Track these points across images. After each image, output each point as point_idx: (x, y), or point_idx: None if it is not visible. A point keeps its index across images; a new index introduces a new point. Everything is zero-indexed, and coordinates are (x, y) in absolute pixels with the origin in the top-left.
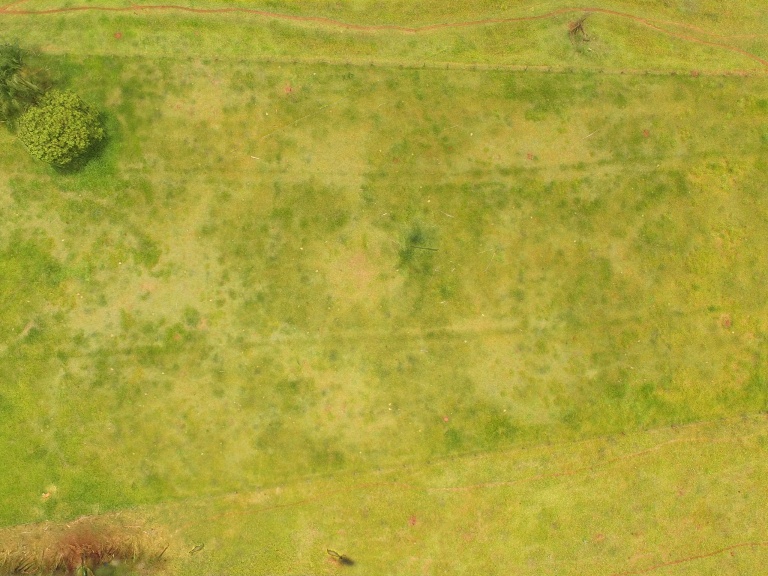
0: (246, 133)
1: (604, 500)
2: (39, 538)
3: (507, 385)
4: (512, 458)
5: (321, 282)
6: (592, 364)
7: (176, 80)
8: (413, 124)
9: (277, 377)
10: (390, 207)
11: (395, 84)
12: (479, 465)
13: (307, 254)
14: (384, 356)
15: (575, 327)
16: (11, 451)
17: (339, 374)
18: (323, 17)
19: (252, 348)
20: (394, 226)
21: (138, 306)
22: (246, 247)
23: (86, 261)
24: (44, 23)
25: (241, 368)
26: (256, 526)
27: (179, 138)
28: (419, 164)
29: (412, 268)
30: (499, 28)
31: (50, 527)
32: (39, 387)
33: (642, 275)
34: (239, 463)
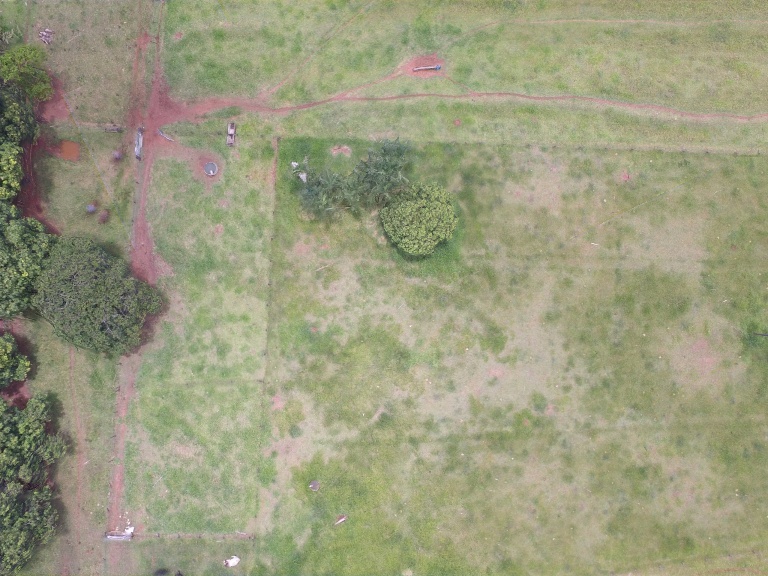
0: (585, 219)
1: None
2: None
3: None
4: None
5: (665, 368)
6: None
7: (515, 167)
8: (749, 211)
9: (625, 463)
10: (730, 294)
11: (730, 171)
12: None
13: (650, 340)
14: (730, 442)
15: None
16: (368, 536)
17: (686, 460)
18: (657, 104)
19: (599, 434)
20: (735, 313)
21: (486, 392)
22: (590, 333)
23: (434, 347)
24: (383, 110)
25: (590, 454)
26: None
27: (520, 224)
28: (757, 251)
29: (754, 355)
30: None
31: None
32: (392, 472)
33: None
34: (590, 548)
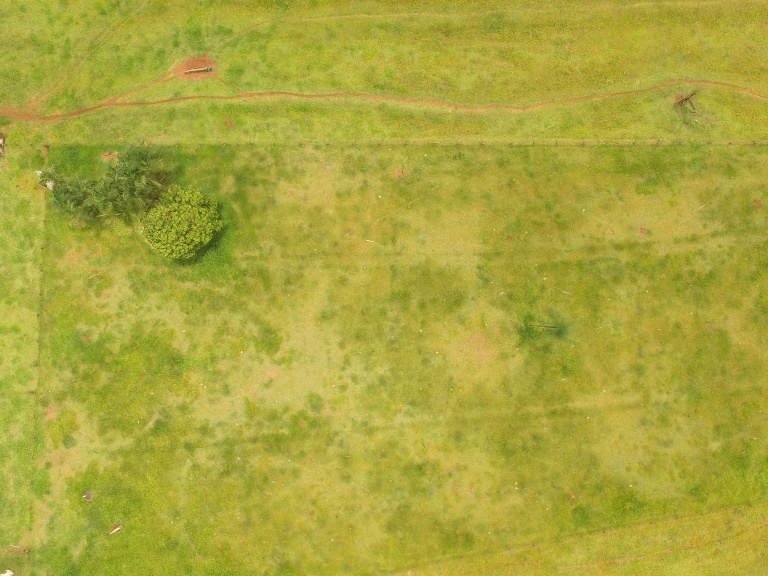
0: (360, 217)
1: (734, 572)
2: None
3: (632, 460)
4: (640, 533)
5: (442, 363)
6: (715, 436)
7: (288, 166)
8: (525, 202)
9: (403, 460)
10: (507, 286)
11: (506, 162)
12: (608, 541)
13: (427, 336)
14: (508, 435)
15: (696, 400)
16: (143, 544)
17: (464, 455)
18: (431, 98)
19: (377, 432)
20: (512, 305)
21: (261, 394)
22: (366, 331)
23: (208, 351)
24: (154, 114)
25: (367, 453)
26: None
27: (294, 224)
28: (533, 242)
29: (532, 346)
30: (606, 103)
31: None
32: (167, 479)
33: (760, 345)
34: (369, 548)
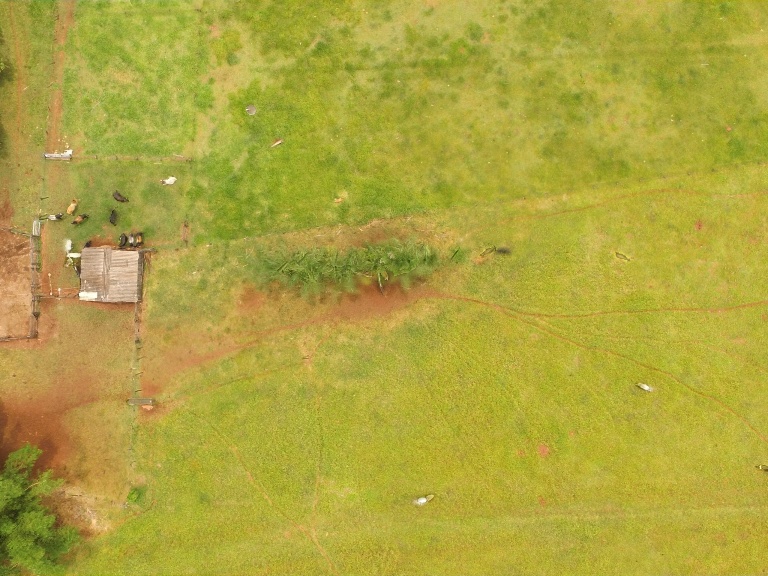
0: None
1: None
2: (332, 241)
3: None
4: None
5: None
6: None
7: None
8: None
9: (560, 89)
10: None
11: None
12: (763, 172)
13: None
14: (665, 69)
15: None
16: (303, 158)
17: (621, 87)
18: None
19: (535, 62)
20: None
21: (422, 21)
22: None
23: None
24: None
25: (525, 80)
26: (546, 229)
27: None
28: None
29: None
30: None
31: (343, 231)
32: (328, 98)
33: None
34: (525, 171)
